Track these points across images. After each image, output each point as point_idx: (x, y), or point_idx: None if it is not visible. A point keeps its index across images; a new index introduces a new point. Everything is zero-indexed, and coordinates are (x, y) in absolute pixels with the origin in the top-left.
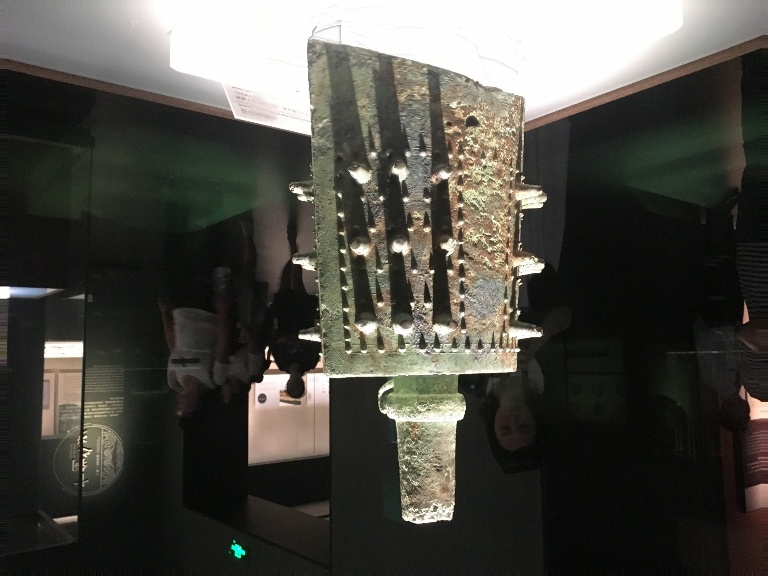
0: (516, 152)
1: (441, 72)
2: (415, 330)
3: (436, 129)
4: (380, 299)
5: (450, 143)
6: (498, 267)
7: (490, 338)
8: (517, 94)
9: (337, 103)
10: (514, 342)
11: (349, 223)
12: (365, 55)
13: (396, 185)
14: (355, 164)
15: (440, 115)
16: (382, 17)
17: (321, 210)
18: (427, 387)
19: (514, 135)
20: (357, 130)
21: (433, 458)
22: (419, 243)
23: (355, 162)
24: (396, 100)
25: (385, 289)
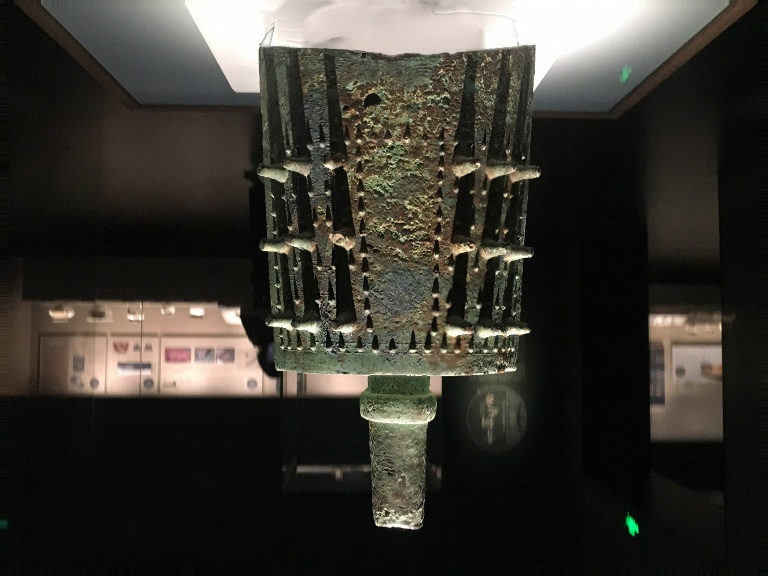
0: (454, 121)
1: (336, 54)
2: (322, 328)
3: (333, 116)
4: (296, 297)
5: (347, 128)
6: (419, 258)
7: (408, 337)
8: (460, 51)
9: (270, 105)
10: (467, 341)
11: (278, 222)
12: (281, 53)
13: (303, 181)
14: (259, 166)
15: (337, 100)
16: (304, 8)
17: (267, 211)
18: (377, 386)
19: (448, 102)
20: (280, 130)
21: (384, 461)
22: (322, 238)
23: (264, 164)
24: (301, 93)
25: (300, 286)
